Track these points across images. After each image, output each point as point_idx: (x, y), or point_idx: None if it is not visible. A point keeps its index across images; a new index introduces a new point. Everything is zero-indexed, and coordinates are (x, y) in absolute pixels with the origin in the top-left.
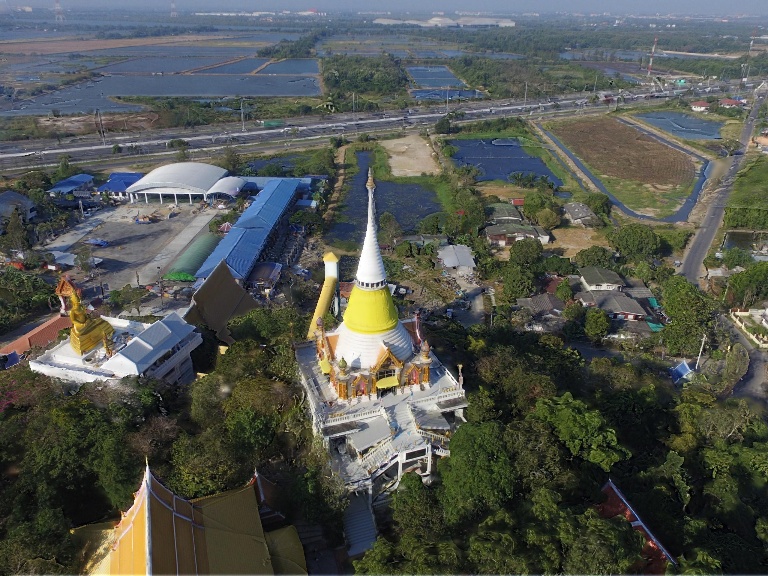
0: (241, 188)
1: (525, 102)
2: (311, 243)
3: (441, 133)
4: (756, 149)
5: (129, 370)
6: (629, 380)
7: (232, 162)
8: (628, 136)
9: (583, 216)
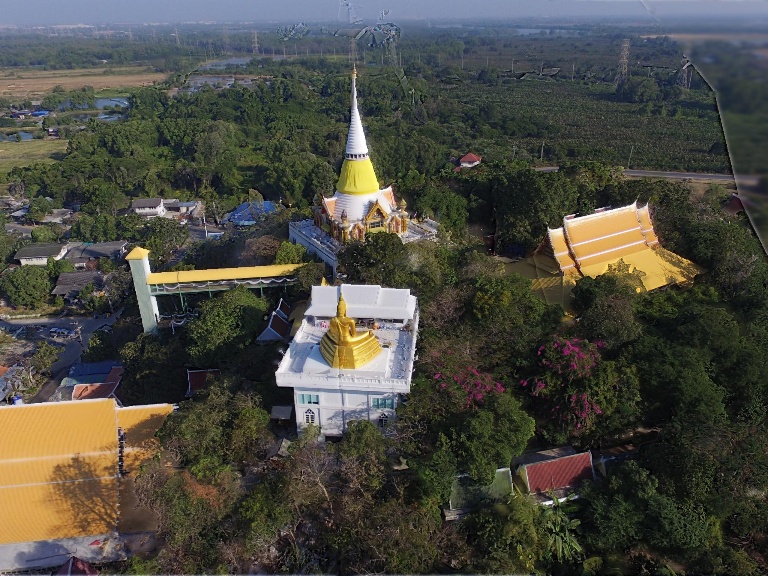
0: None
1: None
2: None
3: None
4: None
5: (414, 301)
6: None
7: None
8: None
9: None
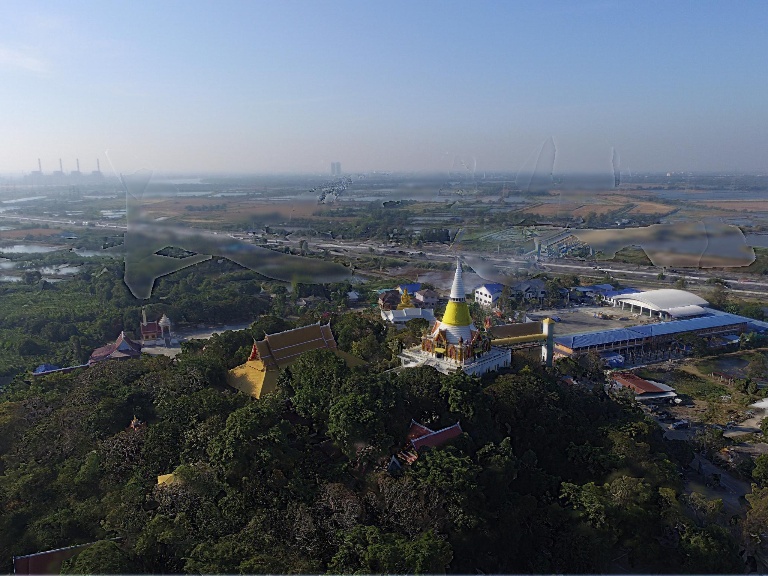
0: (693, 314)
1: None
2: (683, 360)
3: None
4: None
5: None
6: (625, 452)
7: (718, 297)
8: None
9: None
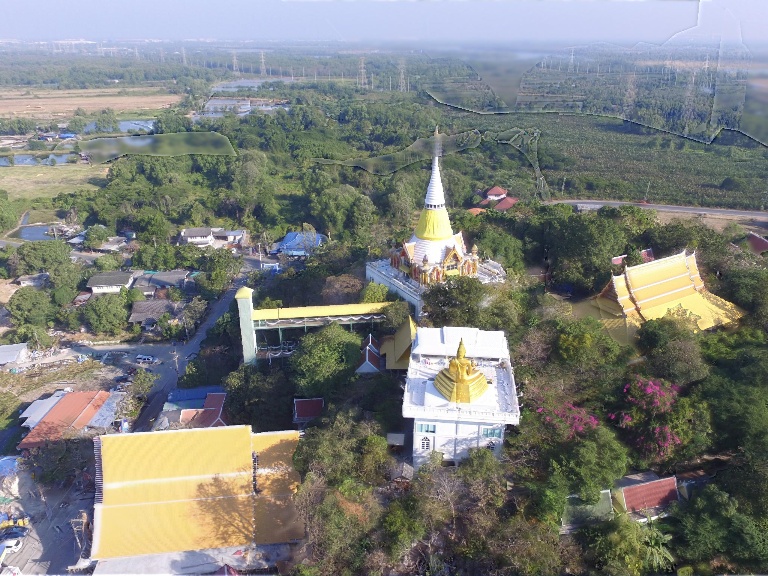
0: None
1: None
2: None
3: None
4: None
5: (505, 341)
6: None
7: None
8: None
9: None
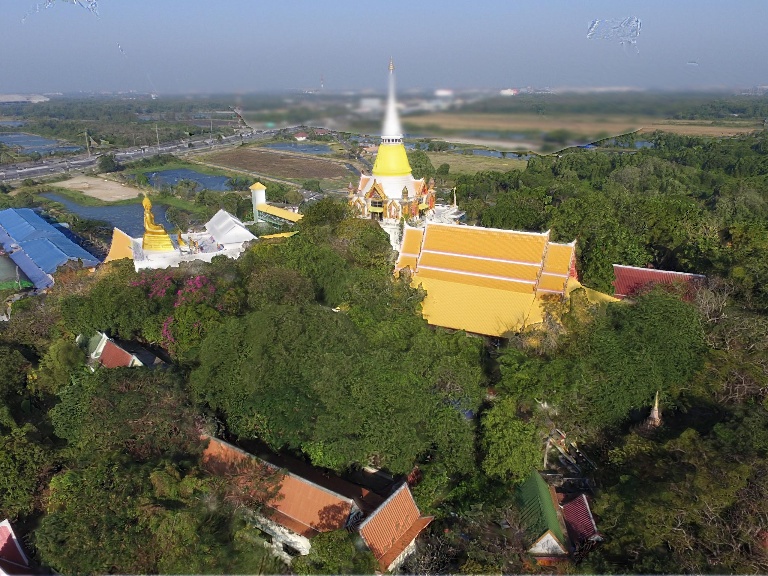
0: None
1: (159, 145)
2: None
3: (107, 172)
4: (367, 154)
5: (247, 238)
6: None
7: None
8: (272, 158)
9: (314, 195)
